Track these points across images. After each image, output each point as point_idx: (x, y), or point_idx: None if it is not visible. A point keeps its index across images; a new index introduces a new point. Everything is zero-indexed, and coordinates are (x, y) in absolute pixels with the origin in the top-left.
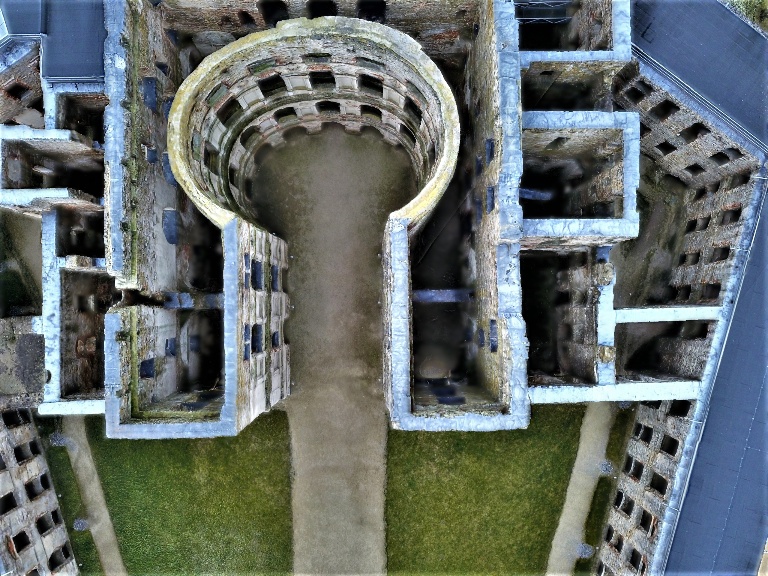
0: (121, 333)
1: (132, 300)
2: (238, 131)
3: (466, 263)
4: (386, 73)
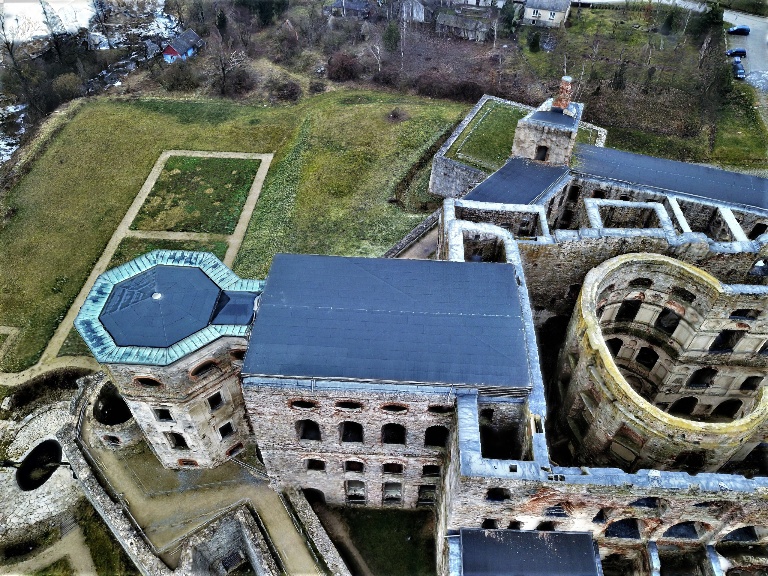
0: None
1: None
2: None
3: (671, 328)
4: None
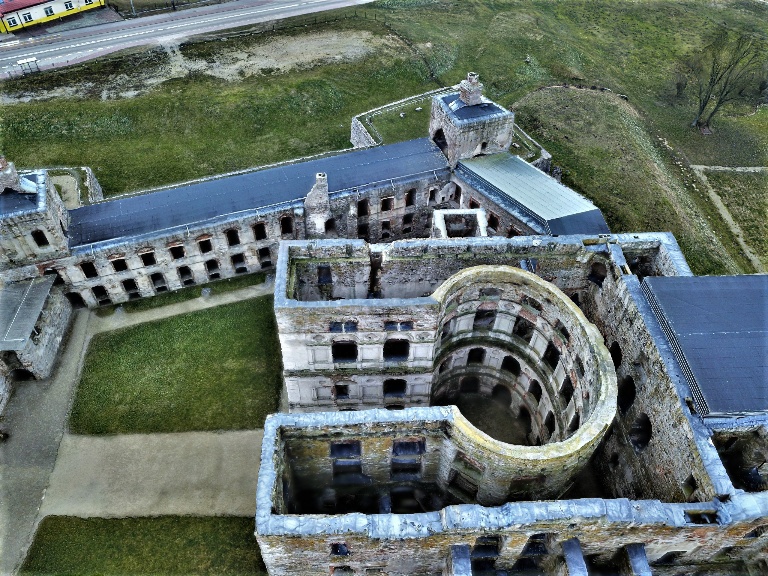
0: (351, 250)
1: (374, 265)
2: (512, 348)
3: None
4: (583, 422)
